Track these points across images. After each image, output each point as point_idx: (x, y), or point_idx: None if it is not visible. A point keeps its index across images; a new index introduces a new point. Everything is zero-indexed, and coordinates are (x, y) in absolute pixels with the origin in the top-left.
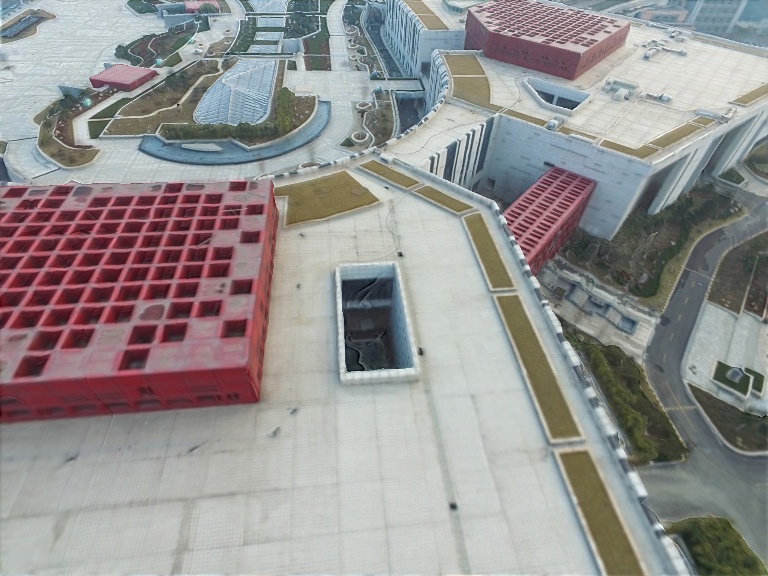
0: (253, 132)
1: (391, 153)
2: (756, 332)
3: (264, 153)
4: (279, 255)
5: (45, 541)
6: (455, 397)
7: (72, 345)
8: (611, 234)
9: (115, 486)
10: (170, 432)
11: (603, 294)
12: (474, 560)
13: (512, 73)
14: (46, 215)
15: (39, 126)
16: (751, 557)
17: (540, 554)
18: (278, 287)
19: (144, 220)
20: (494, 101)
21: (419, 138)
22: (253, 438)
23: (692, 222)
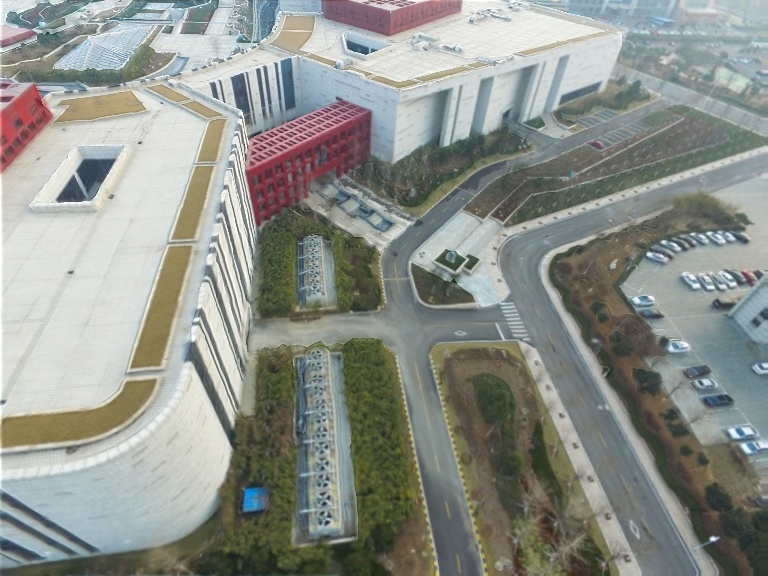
0: (99, 77)
1: (183, 81)
2: (494, 232)
3: None
4: (35, 141)
5: None
6: (117, 220)
7: None
8: (392, 158)
9: None
10: None
11: (374, 204)
12: (65, 297)
13: (339, 30)
14: None
15: None
16: (382, 359)
17: (115, 294)
18: (20, 159)
19: None
20: (305, 49)
21: (216, 72)
22: None
23: (481, 155)
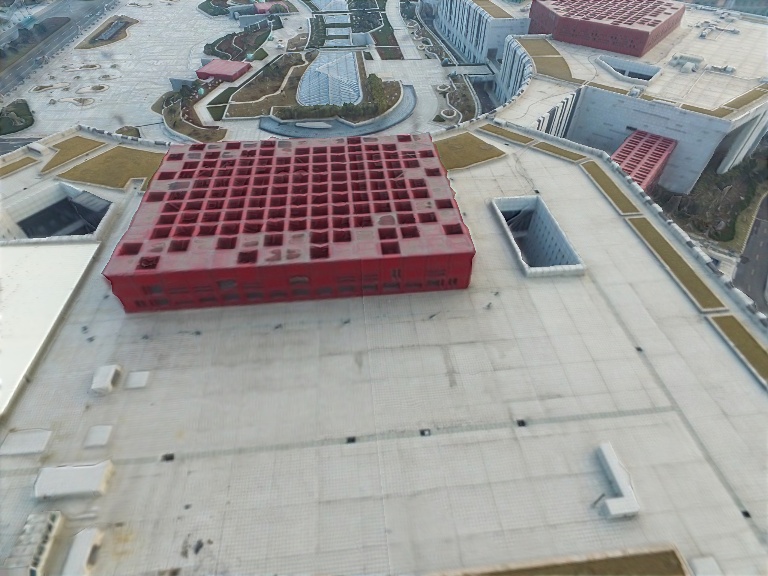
0: (357, 111)
1: (501, 118)
2: None
3: (369, 129)
4: None
5: (353, 368)
6: (617, 284)
7: (339, 240)
8: (688, 189)
9: (386, 338)
10: (410, 306)
11: None
12: (665, 379)
13: (583, 53)
14: (266, 160)
15: (158, 114)
16: None
17: (713, 376)
18: None
19: (343, 163)
20: (575, 76)
21: (520, 107)
22: (473, 310)
23: (757, 180)
